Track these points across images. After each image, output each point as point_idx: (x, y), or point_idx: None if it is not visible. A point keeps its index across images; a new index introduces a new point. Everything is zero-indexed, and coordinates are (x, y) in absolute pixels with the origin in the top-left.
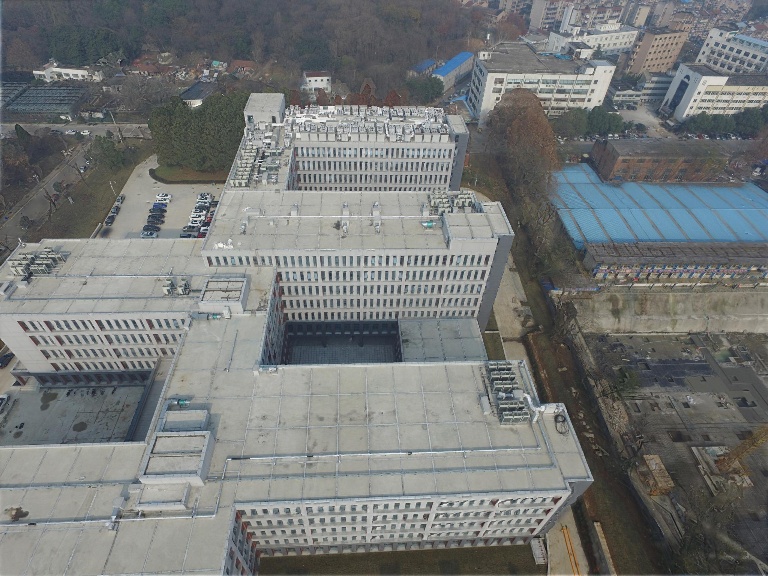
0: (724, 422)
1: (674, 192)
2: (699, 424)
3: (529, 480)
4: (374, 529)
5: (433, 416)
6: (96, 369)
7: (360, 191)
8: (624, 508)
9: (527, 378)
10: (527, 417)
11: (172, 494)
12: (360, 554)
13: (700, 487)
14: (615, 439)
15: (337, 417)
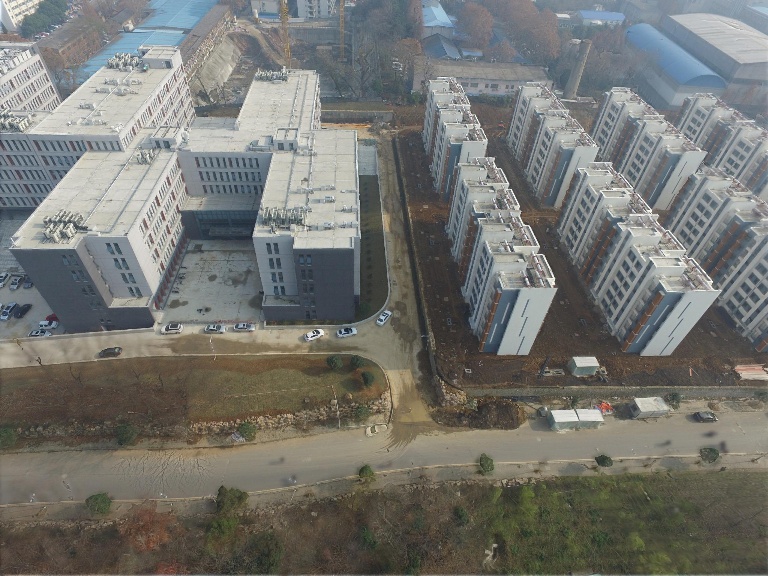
0: None
1: (110, 53)
2: None
3: None
4: None
5: None
6: (168, 259)
7: (81, 86)
8: None
9: None
10: None
11: None
12: None
13: None
14: None
15: (273, 111)
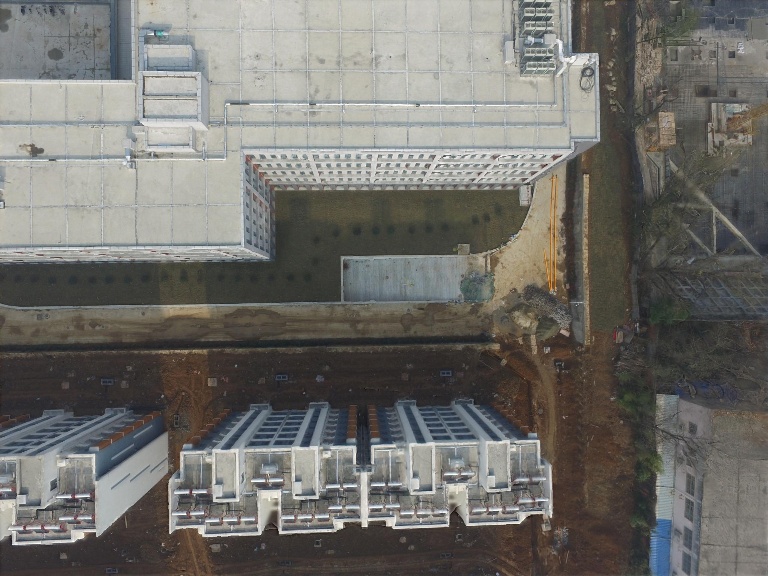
0: (762, 77)
1: None
2: (734, 78)
3: (535, 138)
4: (377, 173)
5: (447, 63)
6: None
7: None
8: (617, 163)
9: (566, 18)
10: (552, 69)
11: (178, 138)
12: (364, 191)
13: (703, 152)
14: (637, 93)
15: (340, 60)
